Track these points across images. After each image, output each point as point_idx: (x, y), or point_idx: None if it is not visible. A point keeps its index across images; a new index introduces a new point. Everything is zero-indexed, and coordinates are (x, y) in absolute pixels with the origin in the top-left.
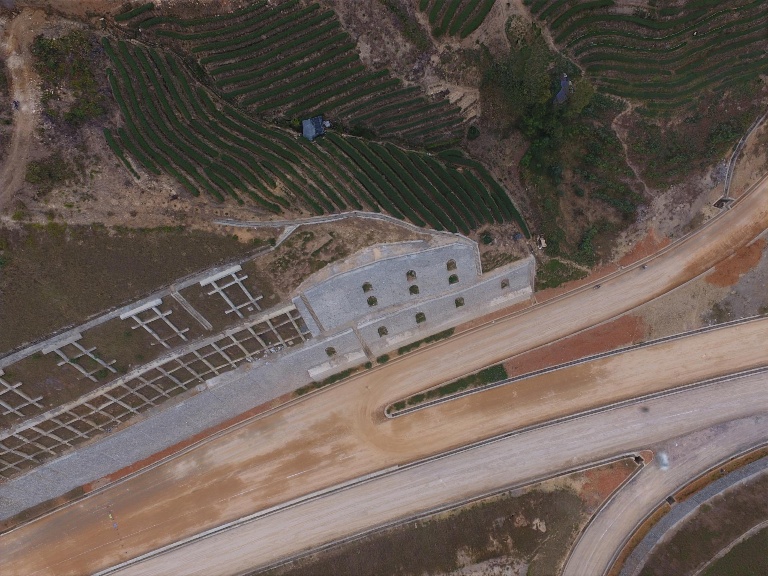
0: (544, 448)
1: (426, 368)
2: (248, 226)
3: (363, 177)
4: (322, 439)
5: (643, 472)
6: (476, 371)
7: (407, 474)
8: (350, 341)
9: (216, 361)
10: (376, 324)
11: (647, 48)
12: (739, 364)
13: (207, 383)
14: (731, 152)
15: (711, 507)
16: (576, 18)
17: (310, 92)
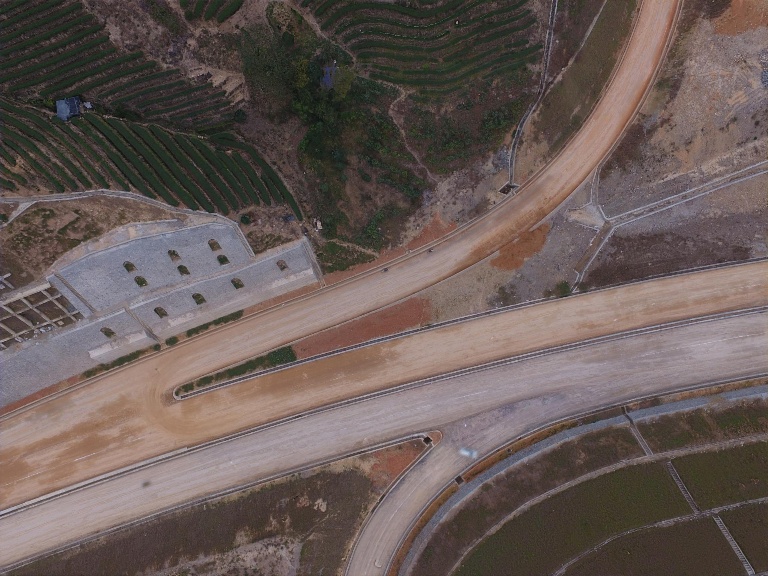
0: (335, 429)
1: (216, 350)
2: None
3: (115, 157)
4: (110, 421)
5: (433, 453)
6: (265, 353)
7: (197, 456)
8: (127, 322)
9: None
10: (150, 305)
11: (413, 36)
12: (526, 346)
13: None
14: (511, 139)
15: (493, 486)
16: (341, 6)
17: (62, 72)
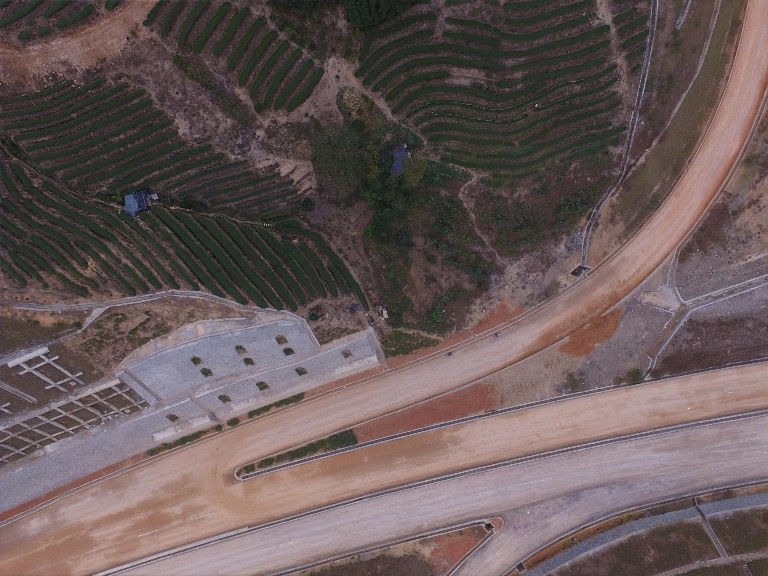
0: (395, 513)
1: (276, 432)
2: (52, 310)
3: (184, 254)
4: (173, 500)
5: (494, 539)
6: (326, 436)
7: (258, 535)
8: (191, 408)
9: (50, 429)
10: (214, 393)
11: (488, 119)
12: (594, 433)
13: (46, 449)
14: (586, 221)
15: None
16: (413, 89)
17: (130, 168)
